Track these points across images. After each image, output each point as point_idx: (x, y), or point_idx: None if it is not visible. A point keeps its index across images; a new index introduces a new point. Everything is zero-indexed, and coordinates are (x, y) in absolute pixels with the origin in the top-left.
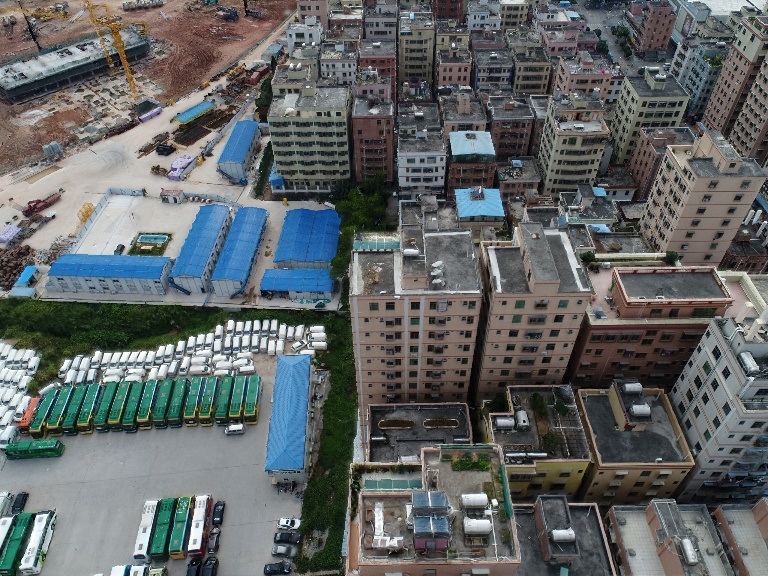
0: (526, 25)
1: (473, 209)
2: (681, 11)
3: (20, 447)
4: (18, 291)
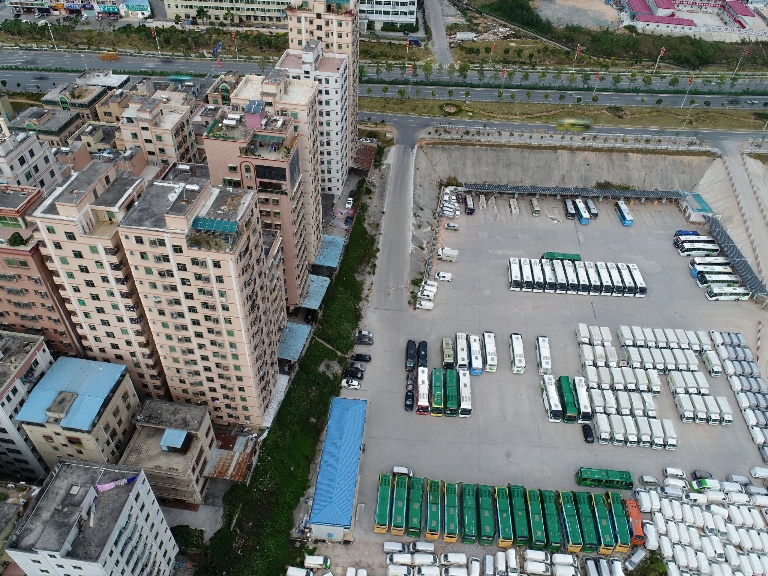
0: None
1: None
2: None
3: (616, 472)
4: None
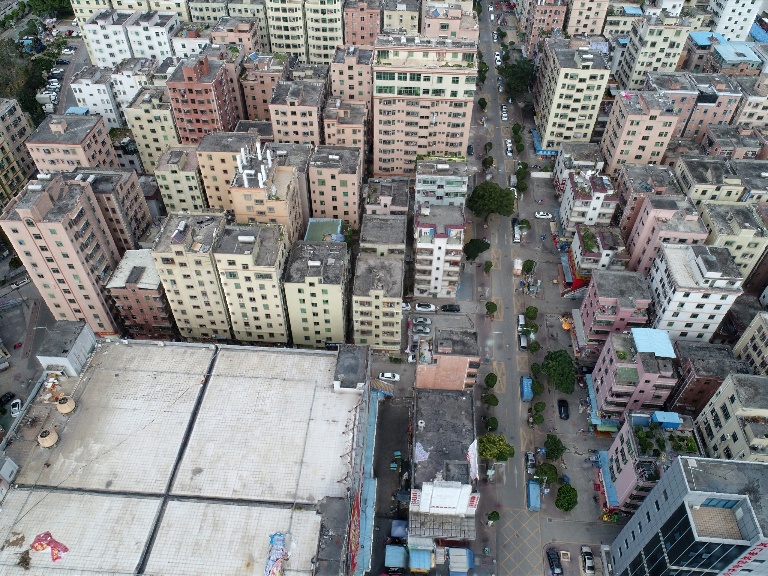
0: (742, 225)
1: None
2: None
3: None
4: None
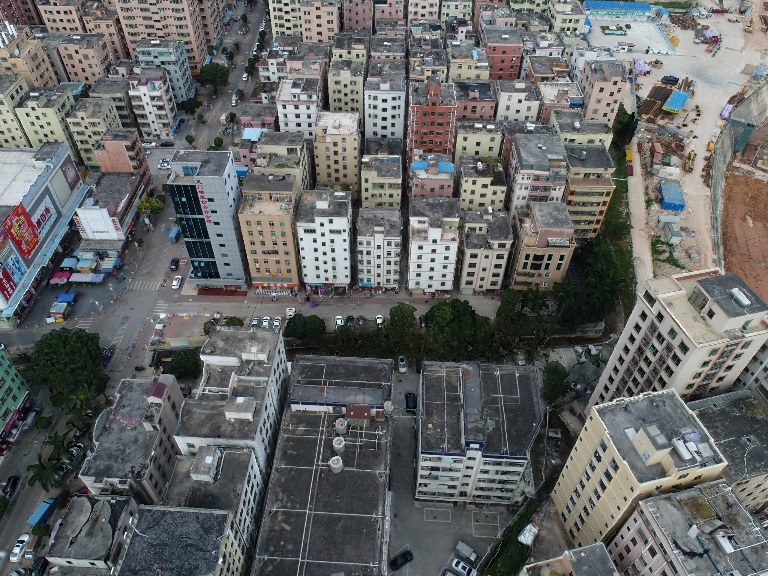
0: (341, 68)
1: None
2: (54, 184)
3: None
4: None
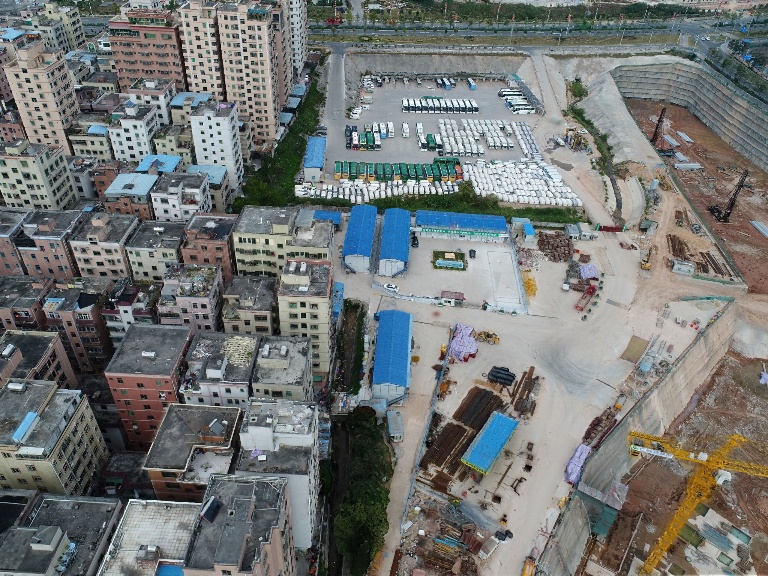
0: None
1: (168, 158)
2: None
3: None
4: (524, 220)
